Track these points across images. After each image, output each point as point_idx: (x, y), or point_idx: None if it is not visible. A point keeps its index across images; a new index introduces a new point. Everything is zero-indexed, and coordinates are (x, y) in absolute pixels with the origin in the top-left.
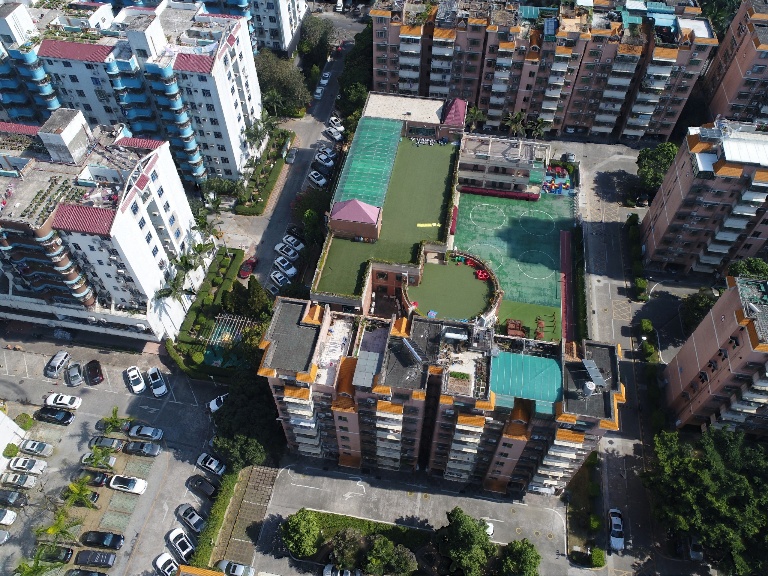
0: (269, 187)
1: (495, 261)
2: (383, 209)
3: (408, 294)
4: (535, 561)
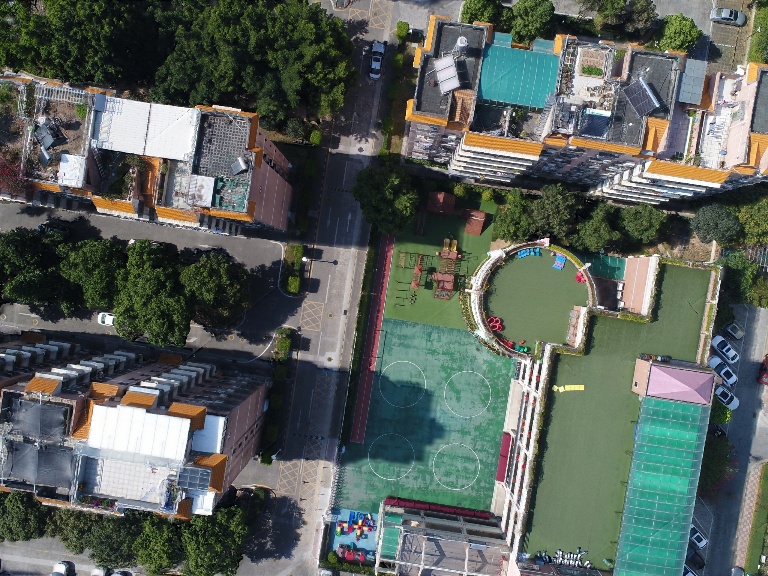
0: (762, 514)
1: (454, 389)
2: (630, 416)
3: (587, 294)
4: (472, 2)
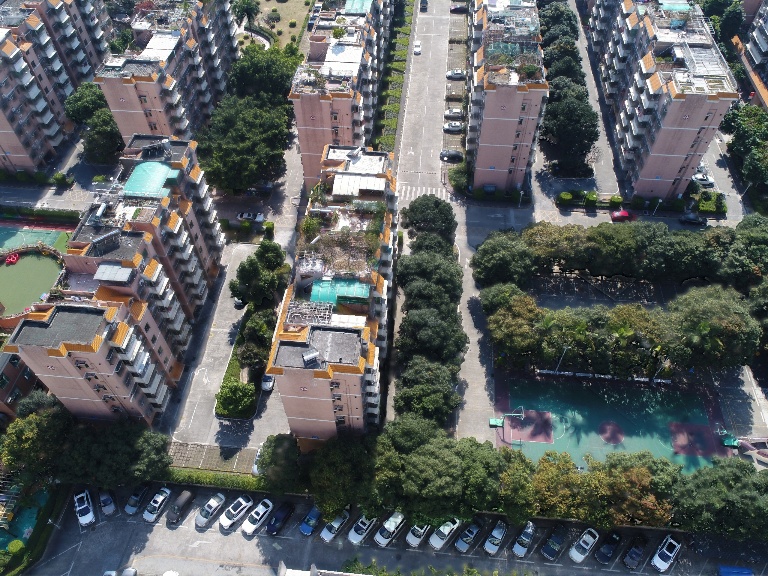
0: None
1: None
2: None
3: None
4: None
